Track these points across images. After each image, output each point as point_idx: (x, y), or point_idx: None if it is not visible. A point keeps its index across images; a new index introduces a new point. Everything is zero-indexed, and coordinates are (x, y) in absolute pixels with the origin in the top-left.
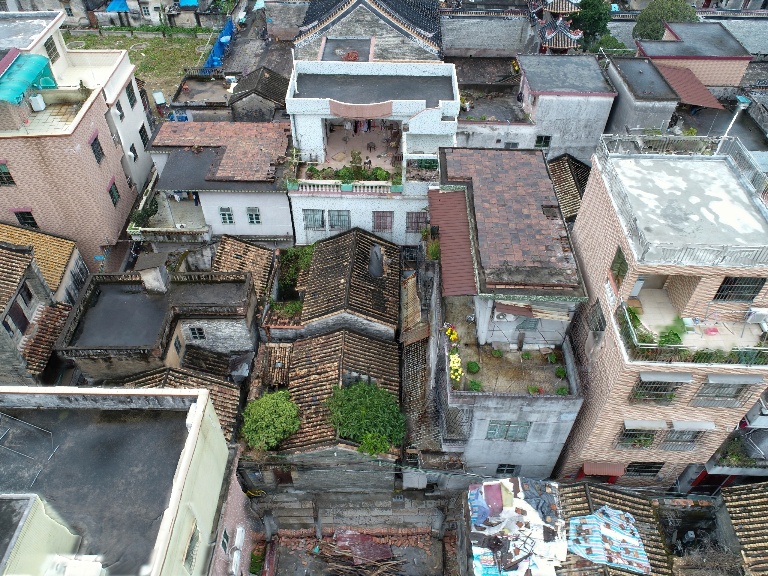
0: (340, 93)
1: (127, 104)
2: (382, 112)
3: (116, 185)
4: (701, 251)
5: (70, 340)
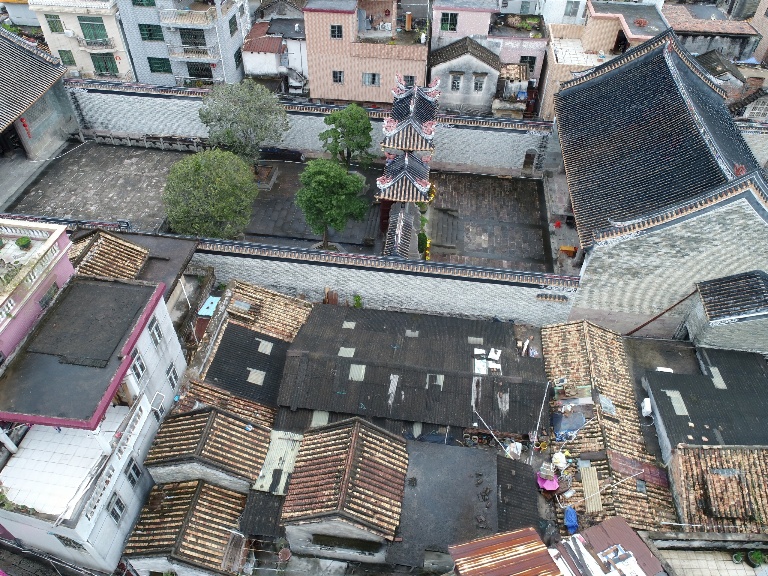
0: None
1: None
2: None
3: (759, 44)
4: None
5: None
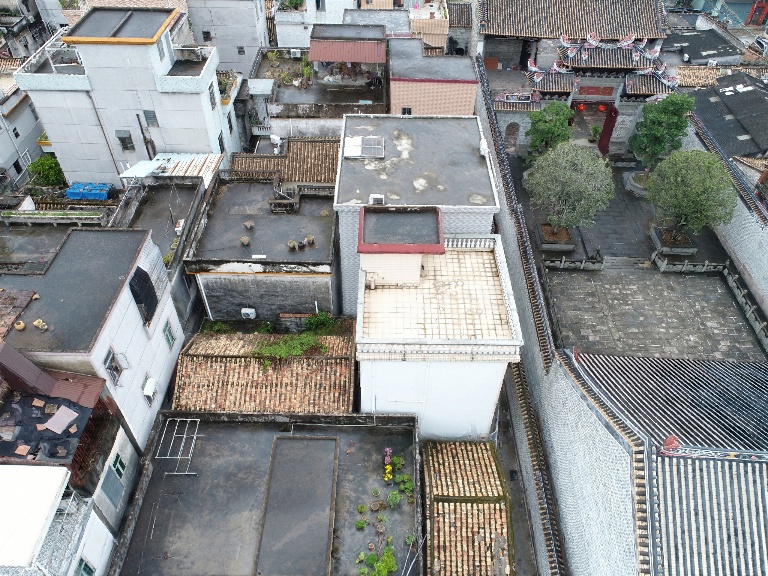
0: None
1: None
2: None
3: None
4: None
5: None
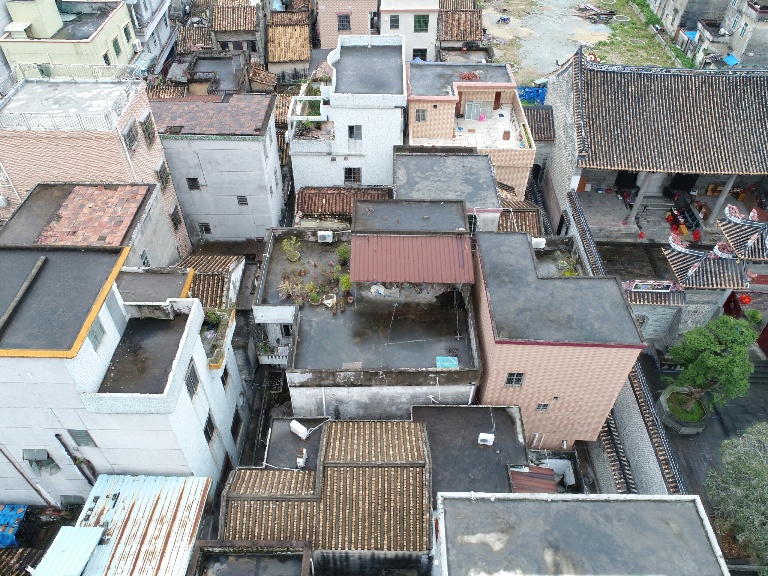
0: (368, 61)
1: (409, 25)
2: (330, 73)
3: None
4: (5, 83)
5: (208, 57)
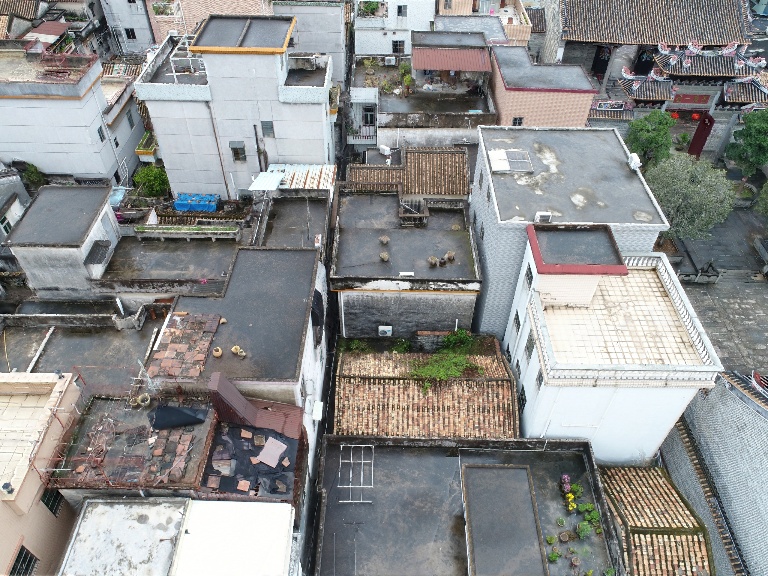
0: None
1: None
2: None
3: None
4: None
5: None
